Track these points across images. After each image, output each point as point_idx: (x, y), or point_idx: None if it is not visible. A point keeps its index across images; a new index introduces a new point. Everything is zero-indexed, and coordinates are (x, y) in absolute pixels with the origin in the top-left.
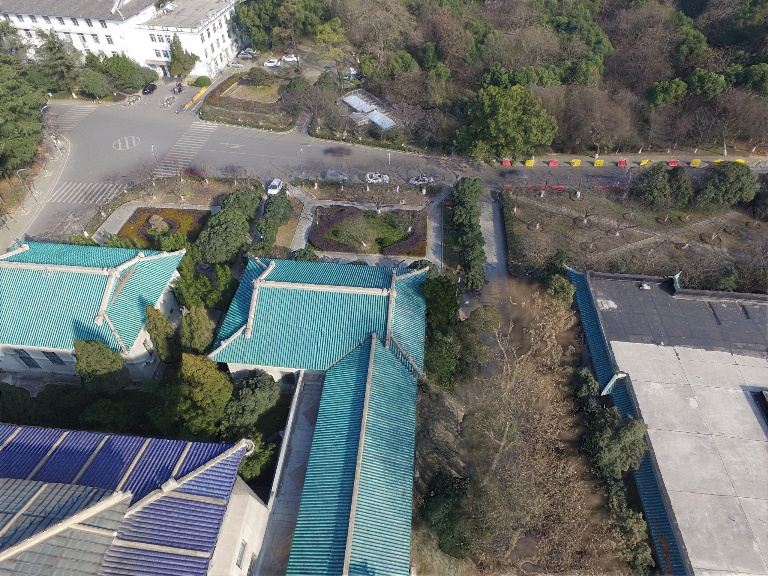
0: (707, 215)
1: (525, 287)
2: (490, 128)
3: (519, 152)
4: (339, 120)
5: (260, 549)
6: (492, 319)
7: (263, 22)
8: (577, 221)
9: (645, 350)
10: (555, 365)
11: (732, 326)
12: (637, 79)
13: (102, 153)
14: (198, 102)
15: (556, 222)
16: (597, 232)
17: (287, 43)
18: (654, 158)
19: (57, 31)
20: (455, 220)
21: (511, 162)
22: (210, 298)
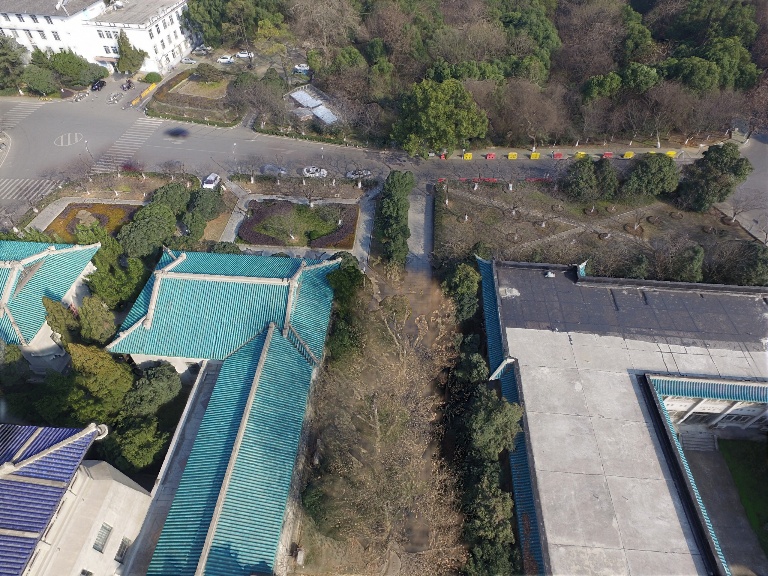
0: (633, 206)
1: (440, 277)
2: (421, 121)
3: (453, 145)
4: (282, 115)
5: (137, 535)
6: (401, 308)
7: (213, 18)
8: (506, 213)
9: (540, 336)
10: (443, 351)
11: (629, 312)
12: (584, 73)
13: (43, 149)
14: (146, 98)
15: (486, 214)
16: (524, 223)
17: (237, 39)
18: (589, 151)
19: (3, 27)
20: (383, 213)
21: (445, 155)
22: (124, 291)
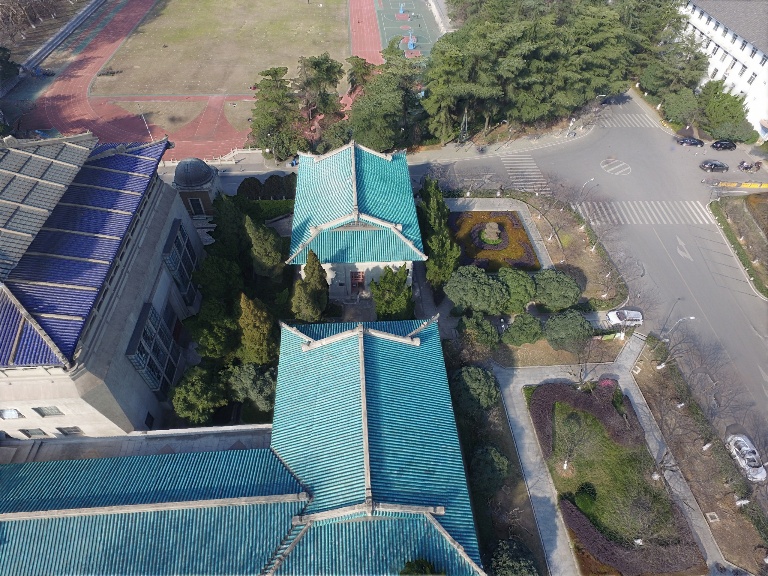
0: None
1: None
2: None
3: None
4: None
5: (94, 436)
6: None
7: None
8: None
9: None
10: None
11: None
12: None
13: (587, 158)
14: (742, 190)
15: None
16: None
17: None
18: None
19: (721, 46)
20: None
21: None
22: None
